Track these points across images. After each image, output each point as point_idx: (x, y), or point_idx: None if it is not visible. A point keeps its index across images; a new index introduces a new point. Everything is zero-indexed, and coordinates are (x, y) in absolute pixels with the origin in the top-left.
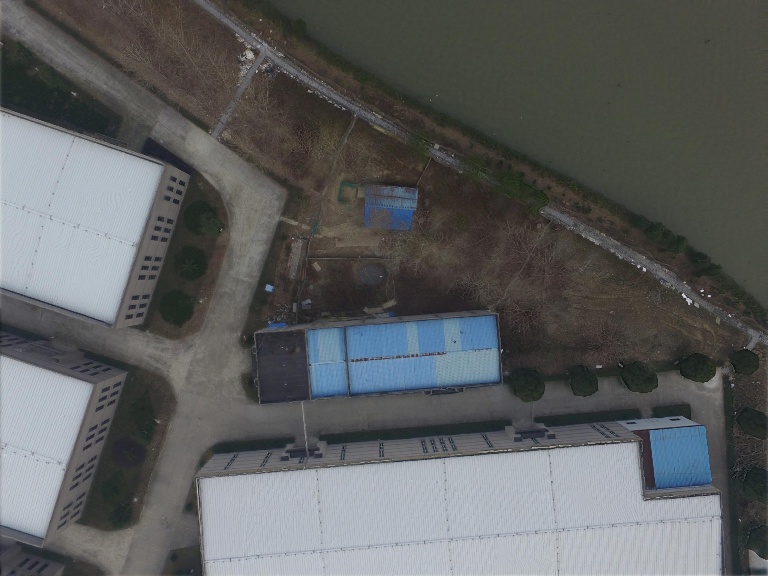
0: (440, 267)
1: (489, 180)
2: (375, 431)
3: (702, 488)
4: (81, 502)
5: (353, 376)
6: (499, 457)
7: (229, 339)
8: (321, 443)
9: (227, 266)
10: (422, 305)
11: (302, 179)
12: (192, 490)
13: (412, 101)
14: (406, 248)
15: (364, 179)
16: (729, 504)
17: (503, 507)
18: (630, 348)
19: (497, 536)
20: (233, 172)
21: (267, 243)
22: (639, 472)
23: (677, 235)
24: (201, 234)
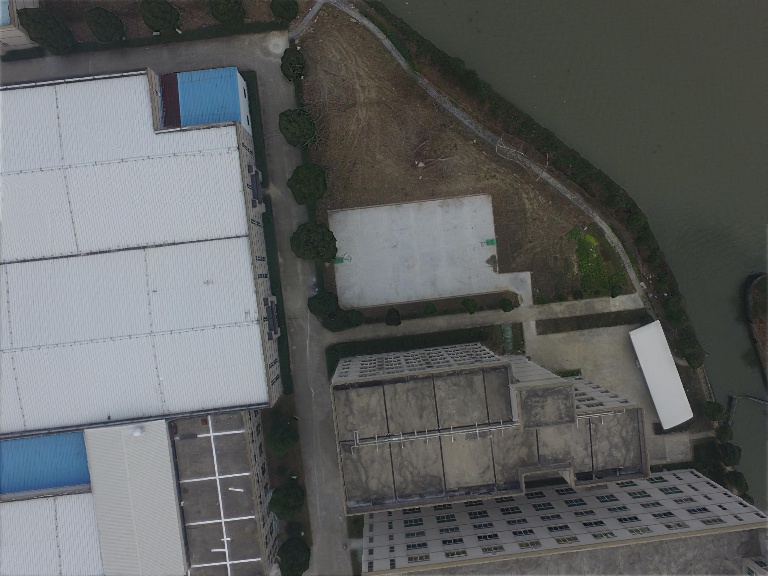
0: None
1: None
2: None
3: None
4: None
5: None
6: (3, 94)
7: None
8: None
9: None
10: None
11: None
12: None
13: None
14: None
15: None
16: None
17: (7, 145)
18: (187, 12)
19: (0, 175)
20: None
21: None
22: (151, 105)
23: None
24: None
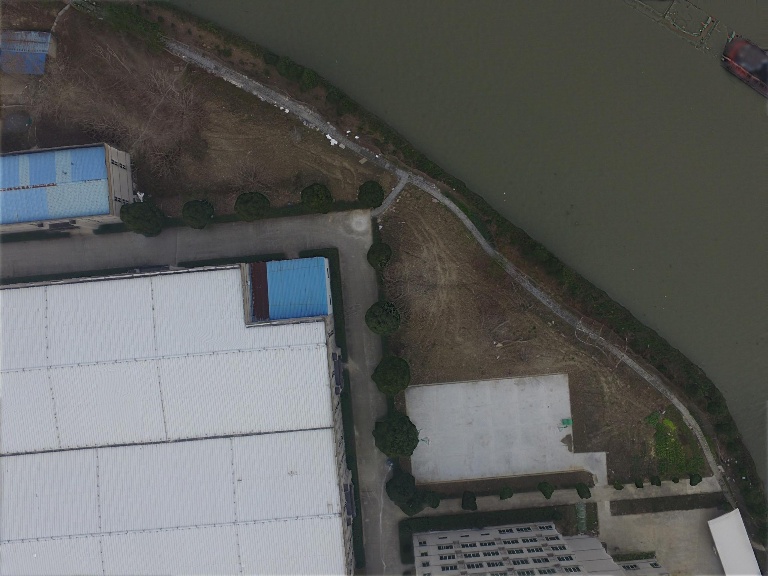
0: (77, 111)
1: None
2: (19, 277)
3: None
4: None
5: None
6: (101, 285)
7: None
8: None
9: None
10: None
11: None
12: None
13: None
14: (47, 94)
15: (3, 27)
16: (382, 352)
17: (103, 334)
18: (273, 190)
19: (96, 364)
20: None
21: None
22: (243, 299)
23: (302, 68)
24: None
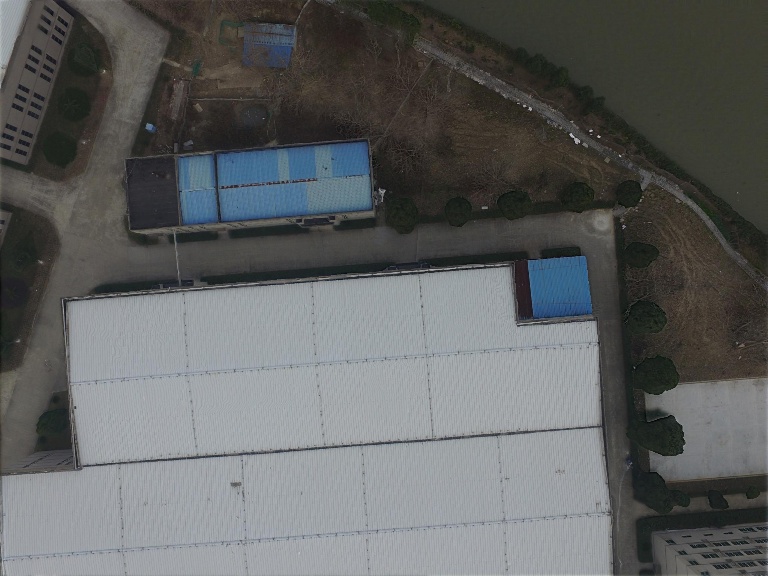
0: (320, 105)
1: (371, 20)
2: (257, 273)
3: (580, 316)
4: None
5: (224, 203)
6: (368, 281)
7: (112, 181)
8: (201, 282)
9: (110, 108)
10: None
11: (184, 21)
12: None
13: None
14: (287, 88)
15: (244, 18)
16: (623, 351)
17: (372, 332)
18: (516, 188)
19: (365, 361)
20: (117, 16)
21: (150, 85)
22: (512, 297)
23: None
24: (84, 75)
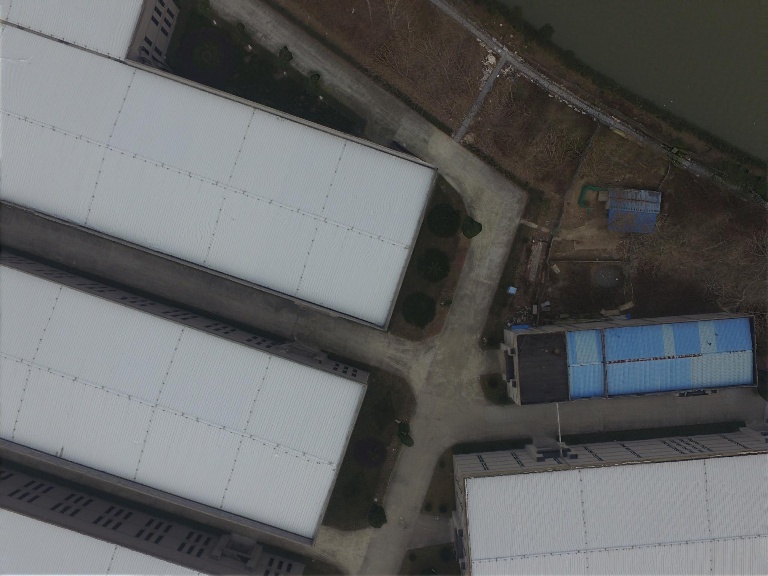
0: (679, 270)
1: (725, 184)
2: (611, 432)
3: None
4: None
5: (610, 378)
6: (758, 458)
7: (469, 341)
8: (562, 444)
9: (467, 268)
10: (659, 307)
11: (543, 182)
12: (430, 490)
13: (651, 105)
14: (644, 251)
15: (606, 182)
16: None
17: (763, 508)
18: None
19: (758, 536)
20: (474, 175)
21: (507, 246)
22: None
23: None
24: (444, 237)
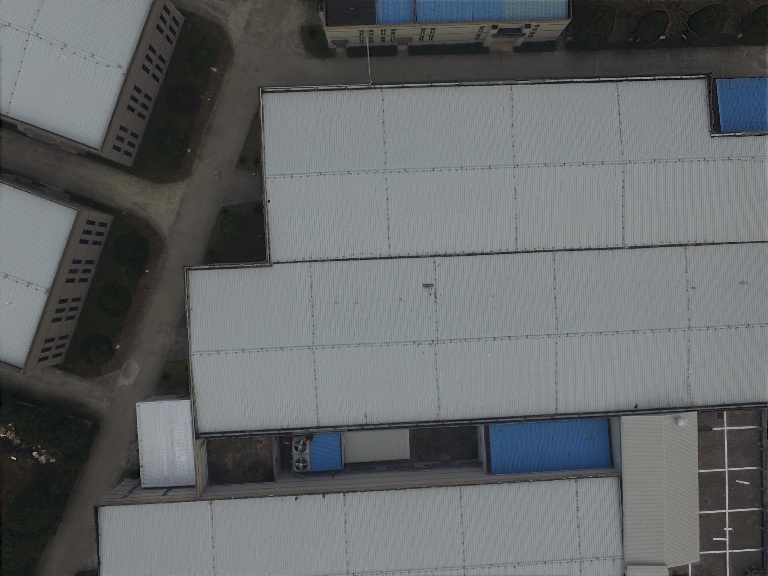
0: None
1: None
2: None
3: None
4: (134, 145)
5: (420, 5)
6: (567, 87)
7: None
8: None
9: None
10: None
11: None
12: (247, 144)
13: None
14: None
15: None
16: None
17: (570, 136)
18: None
19: (563, 165)
20: None
21: None
22: (707, 109)
23: None
24: None
